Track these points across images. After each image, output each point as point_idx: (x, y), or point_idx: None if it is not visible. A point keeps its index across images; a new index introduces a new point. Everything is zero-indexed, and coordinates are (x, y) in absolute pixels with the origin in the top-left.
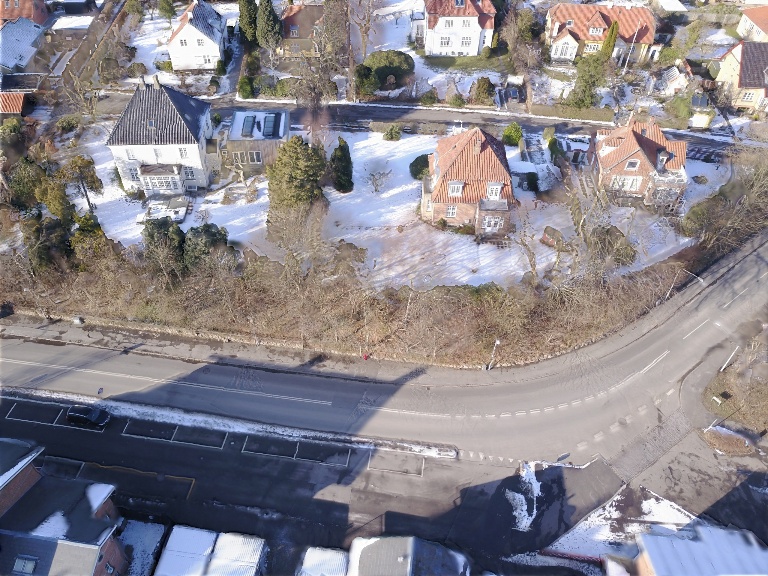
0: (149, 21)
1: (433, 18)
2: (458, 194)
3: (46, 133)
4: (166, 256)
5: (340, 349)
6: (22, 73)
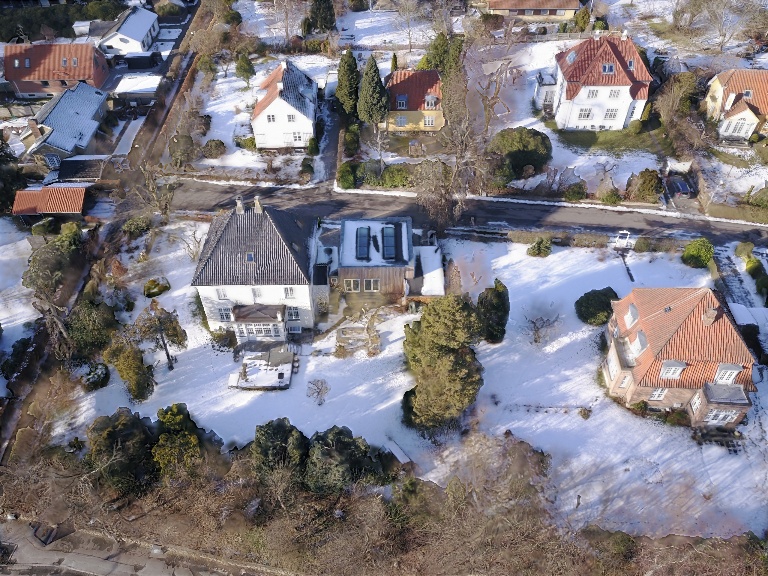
0: (223, 79)
1: (572, 86)
2: (674, 376)
3: (110, 236)
4: (286, 487)
5: None
6: (82, 156)
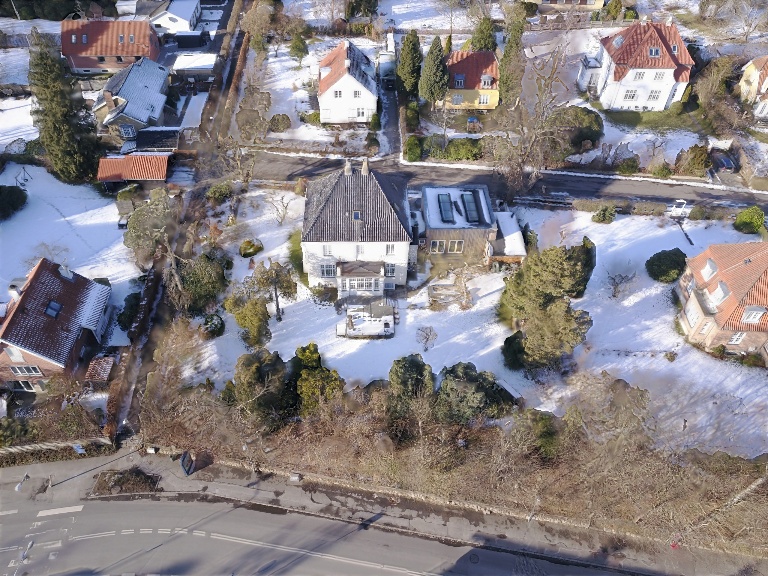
0: (274, 58)
1: (620, 69)
2: (753, 320)
3: (193, 203)
4: (427, 413)
5: (639, 532)
6: (156, 127)
